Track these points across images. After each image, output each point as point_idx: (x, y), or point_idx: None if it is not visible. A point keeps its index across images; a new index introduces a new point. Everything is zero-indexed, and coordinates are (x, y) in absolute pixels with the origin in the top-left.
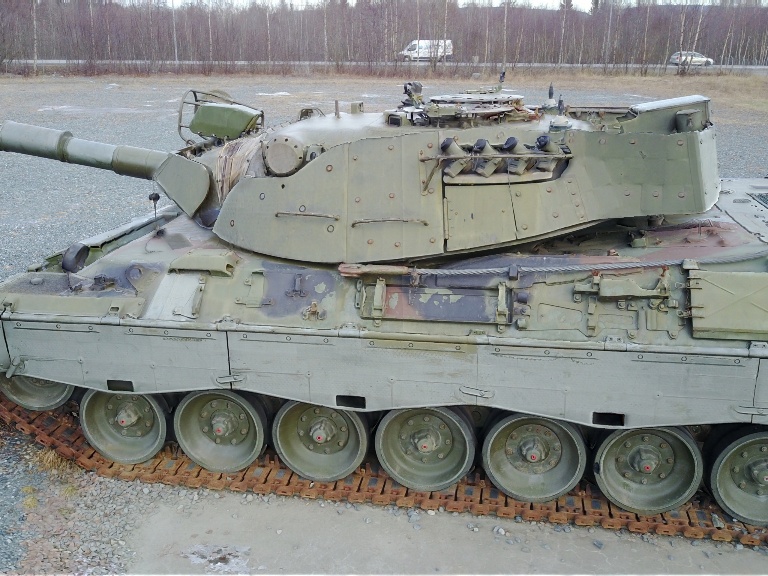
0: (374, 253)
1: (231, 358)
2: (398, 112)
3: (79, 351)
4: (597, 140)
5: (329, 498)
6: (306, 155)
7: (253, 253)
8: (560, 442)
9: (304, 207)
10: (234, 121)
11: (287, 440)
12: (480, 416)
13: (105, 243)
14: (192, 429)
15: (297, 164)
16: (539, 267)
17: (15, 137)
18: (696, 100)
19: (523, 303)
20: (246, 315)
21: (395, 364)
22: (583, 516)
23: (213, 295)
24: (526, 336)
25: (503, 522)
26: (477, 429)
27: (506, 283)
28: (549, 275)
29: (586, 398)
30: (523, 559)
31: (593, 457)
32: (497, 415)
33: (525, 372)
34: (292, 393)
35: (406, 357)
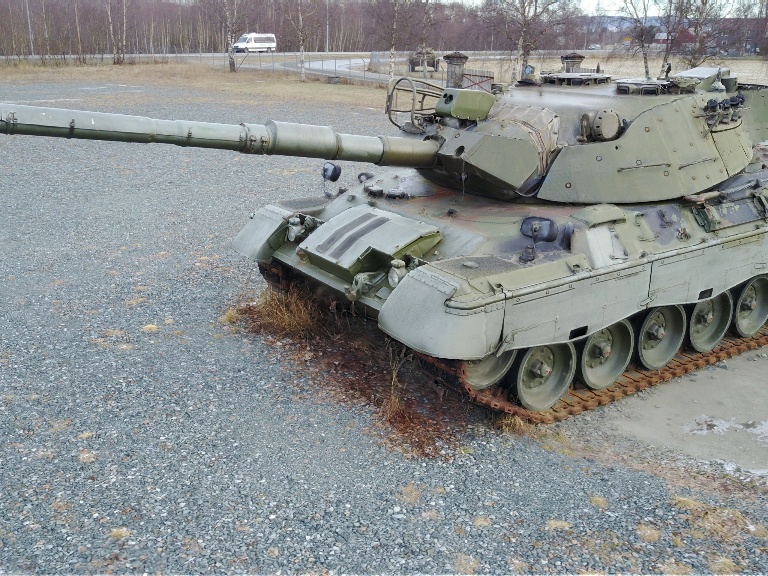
0: (699, 185)
1: (652, 283)
2: (647, 85)
3: (557, 311)
4: None
5: None
6: (620, 122)
7: None
8: (756, 293)
9: (640, 161)
10: (483, 103)
11: None
12: None
13: None
14: None
15: (617, 129)
16: None
17: (293, 138)
18: (724, 70)
19: None
20: (651, 248)
21: (731, 258)
22: None
23: (625, 238)
24: None
25: (753, 352)
26: None
27: None
28: (766, 183)
29: None
30: None
31: None
32: None
33: None
34: (679, 299)
35: (736, 252)
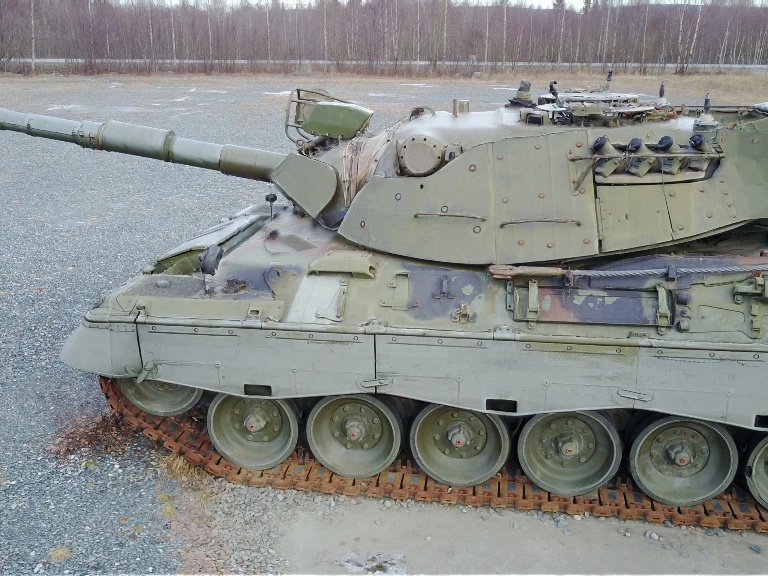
0: (526, 254)
1: (378, 362)
2: (537, 111)
3: (216, 355)
4: (750, 139)
5: (470, 503)
6: (445, 155)
7: (389, 254)
8: (708, 445)
9: (446, 208)
10: (349, 120)
11: (423, 445)
12: (620, 419)
13: (220, 244)
14: (323, 434)
15: (435, 164)
16: (698, 268)
17: (119, 137)
18: None
19: (682, 305)
20: (393, 318)
21: (551, 367)
22: (735, 520)
23: (356, 298)
24: (688, 338)
25: (652, 527)
26: (620, 432)
27: (663, 284)
28: (707, 276)
29: (750, 401)
30: (684, 564)
31: (745, 460)
32: (644, 418)
33: (687, 375)
34: (440, 397)
35: (563, 360)
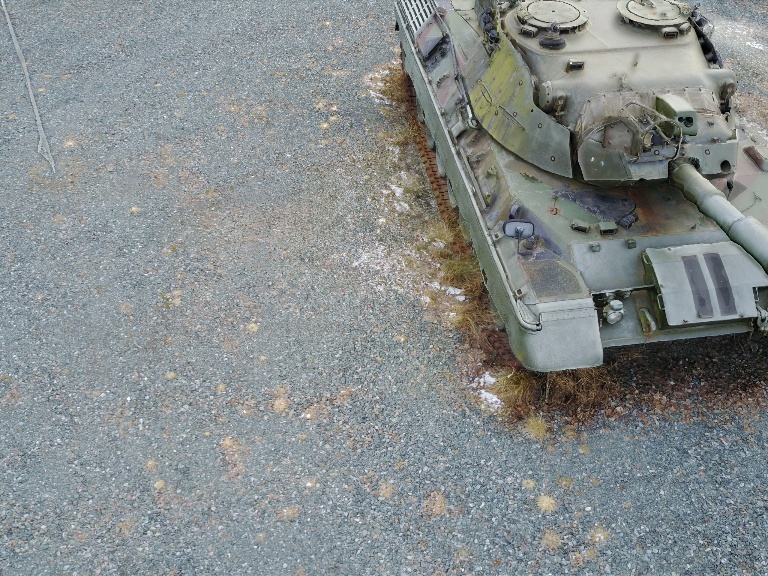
0: None
1: None
2: (685, 26)
3: None
4: None
5: None
6: None
7: None
8: None
9: None
10: None
11: None
12: None
13: None
14: None
15: None
16: None
17: None
18: None
19: None
20: None
21: None
22: None
23: None
24: None
25: None
26: None
27: None
28: None
29: None
30: None
31: None
32: None
33: None
34: None
35: None
